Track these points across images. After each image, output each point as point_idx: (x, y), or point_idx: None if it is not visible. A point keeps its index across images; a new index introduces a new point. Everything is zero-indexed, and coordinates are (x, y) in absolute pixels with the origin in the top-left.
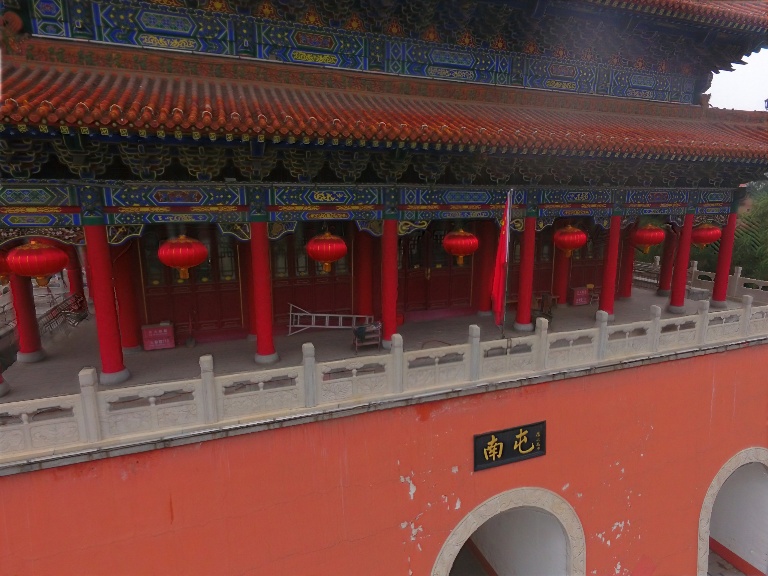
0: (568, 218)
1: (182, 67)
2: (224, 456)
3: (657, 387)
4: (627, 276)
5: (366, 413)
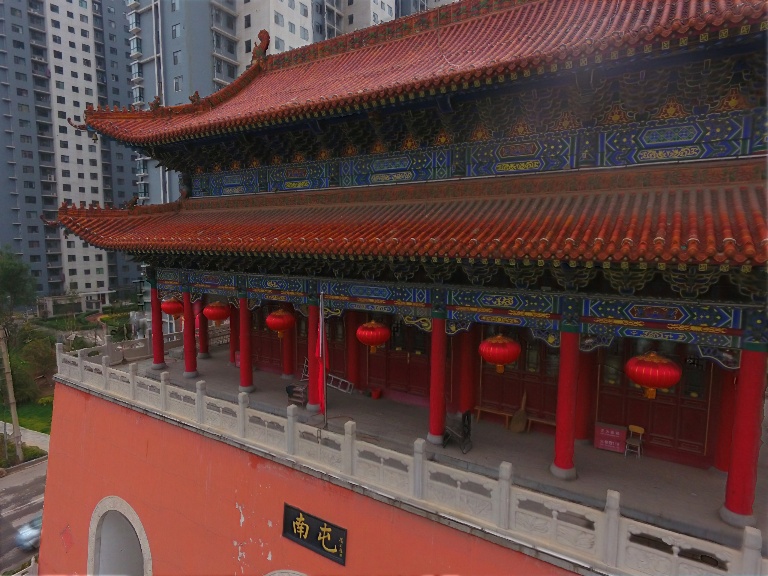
0: (490, 325)
1: (232, 204)
2: (165, 432)
3: None
4: (721, 434)
5: None
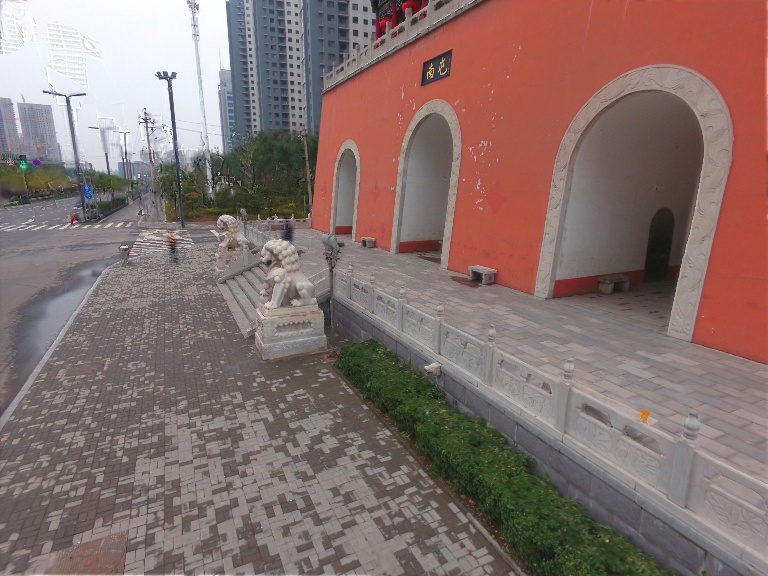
0: None
1: None
2: (370, 75)
3: (530, 3)
4: None
5: (396, 53)
